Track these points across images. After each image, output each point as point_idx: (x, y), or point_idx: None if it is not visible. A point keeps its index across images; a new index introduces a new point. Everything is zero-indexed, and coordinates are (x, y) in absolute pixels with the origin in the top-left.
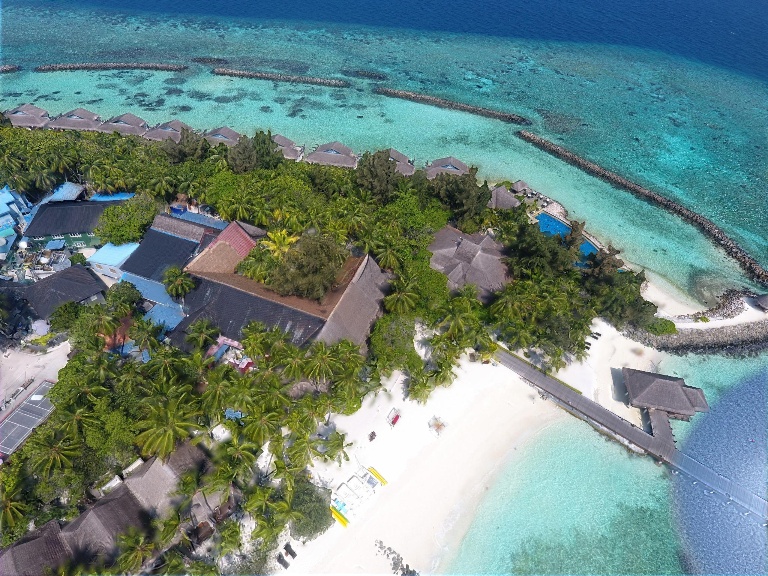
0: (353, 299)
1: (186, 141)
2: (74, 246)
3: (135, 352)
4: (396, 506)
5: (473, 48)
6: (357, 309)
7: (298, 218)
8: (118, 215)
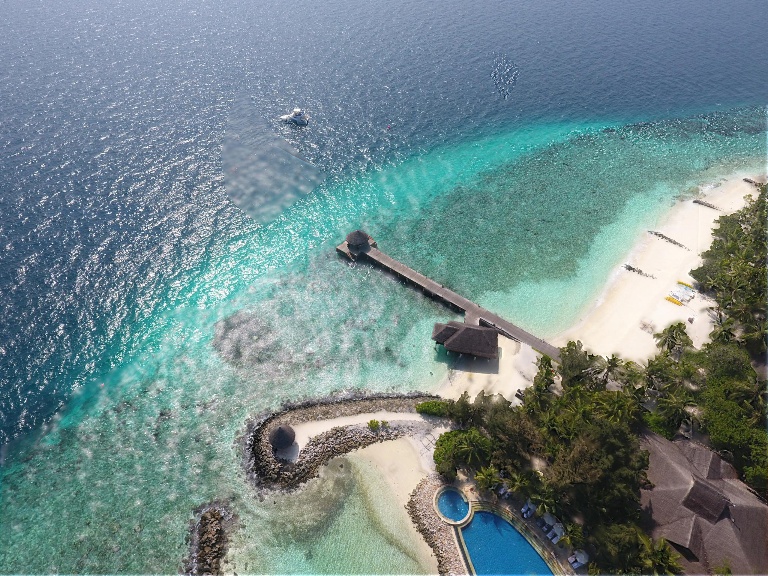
0: None
1: None
2: None
3: None
4: (653, 290)
5: None
6: None
7: None
8: None
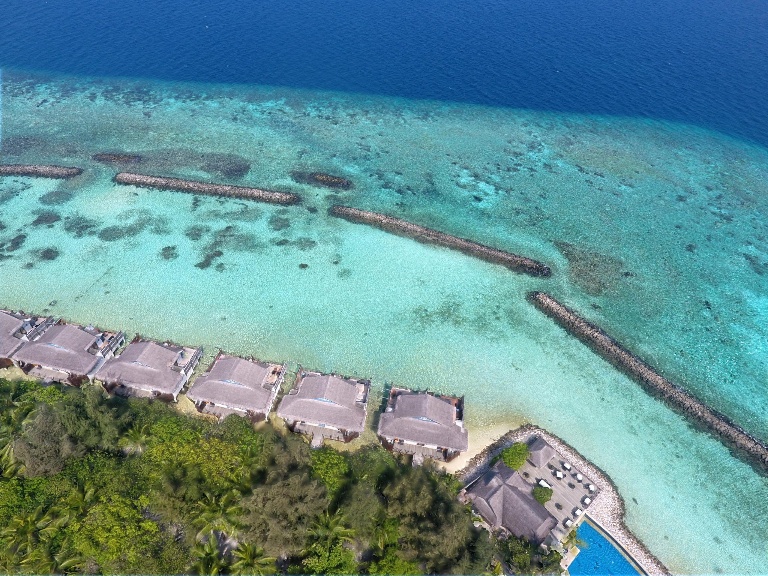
0: None
1: None
2: None
3: None
4: None
5: (470, 129)
6: None
7: None
8: None
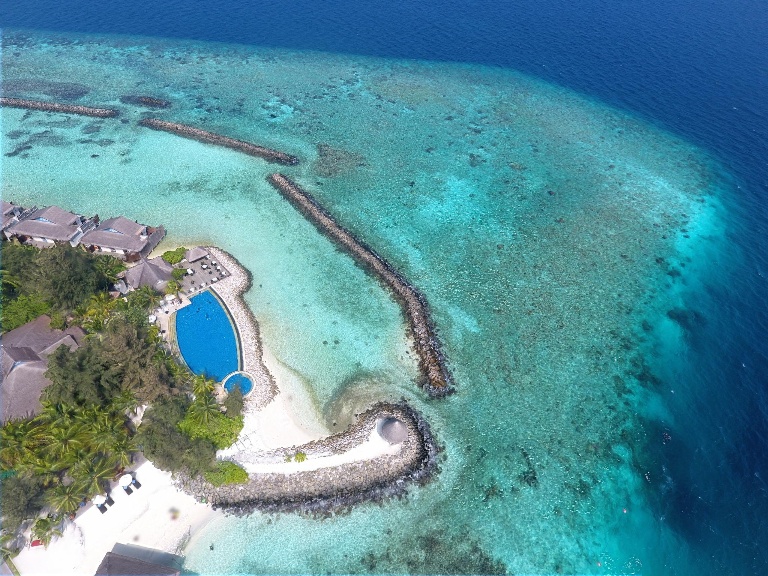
0: None
1: None
2: None
3: None
4: None
5: (302, 68)
6: None
7: None
8: None
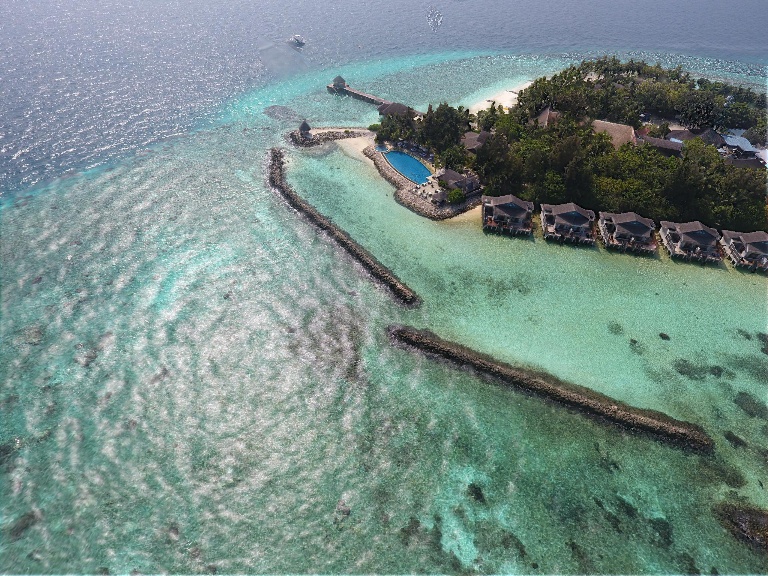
0: None
1: None
2: None
3: None
4: None
5: None
6: None
7: None
8: None
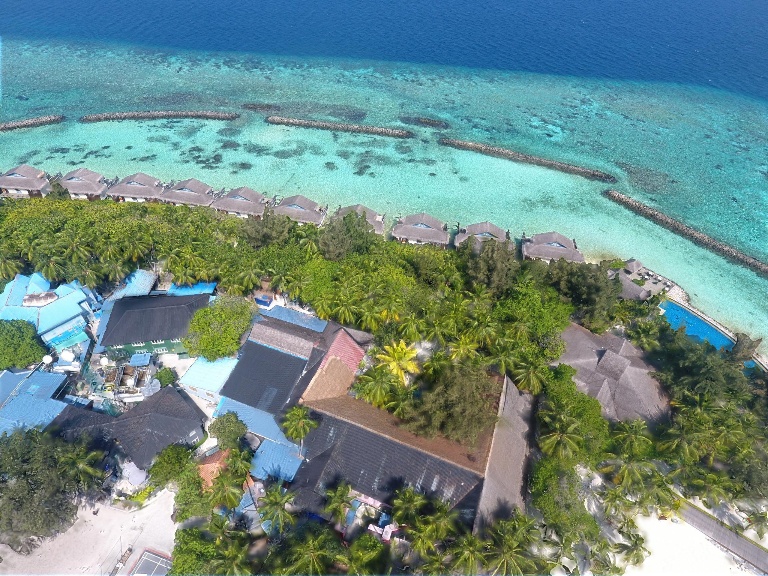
0: (502, 439)
1: (271, 222)
2: (154, 352)
3: (251, 511)
4: None
5: (530, 89)
6: (507, 451)
7: (418, 327)
8: (210, 323)
